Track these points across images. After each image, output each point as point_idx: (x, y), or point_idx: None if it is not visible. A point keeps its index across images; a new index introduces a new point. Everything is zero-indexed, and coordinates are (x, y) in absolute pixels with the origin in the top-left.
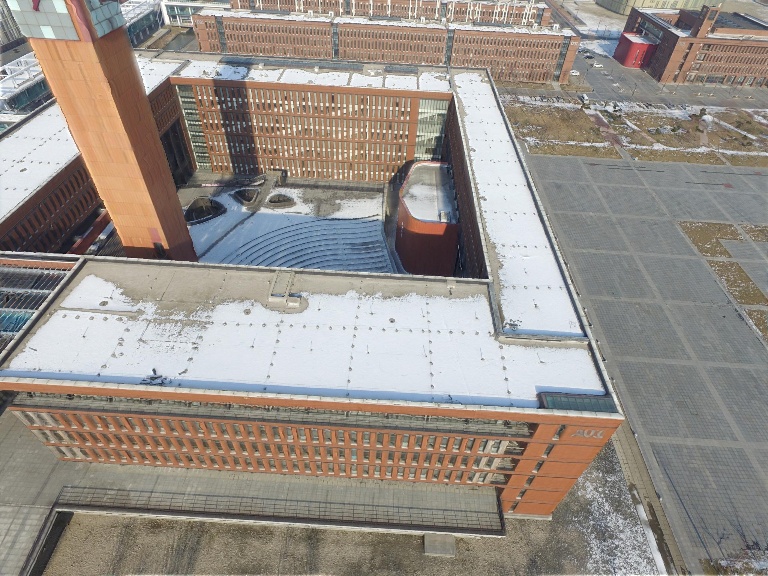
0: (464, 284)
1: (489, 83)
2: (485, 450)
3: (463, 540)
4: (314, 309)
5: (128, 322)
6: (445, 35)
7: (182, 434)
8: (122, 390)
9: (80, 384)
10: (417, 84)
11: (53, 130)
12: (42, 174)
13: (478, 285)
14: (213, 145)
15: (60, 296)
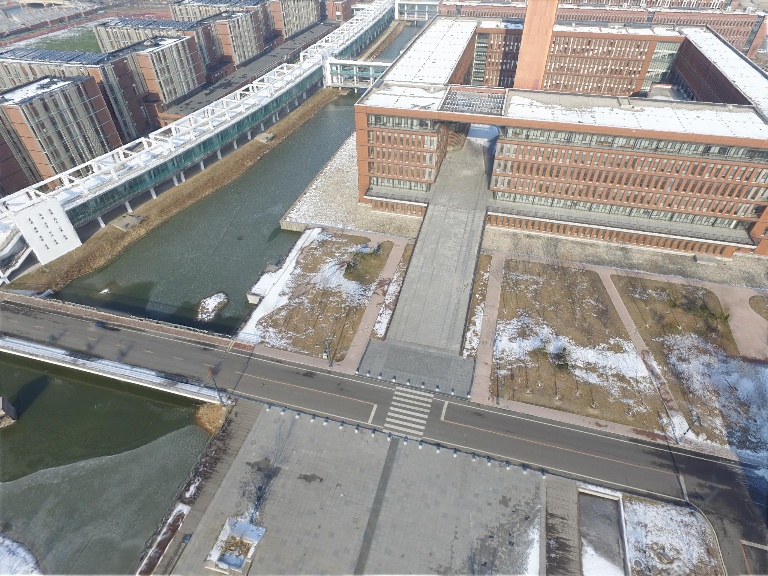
0: (737, 108)
1: (711, 33)
2: (757, 180)
3: (720, 261)
4: (649, 111)
5: (550, 109)
6: (645, 16)
7: (578, 164)
8: (570, 124)
9: (550, 120)
10: (654, 33)
11: (431, 48)
12: (447, 63)
13: (746, 109)
14: (488, 79)
15: (507, 100)
